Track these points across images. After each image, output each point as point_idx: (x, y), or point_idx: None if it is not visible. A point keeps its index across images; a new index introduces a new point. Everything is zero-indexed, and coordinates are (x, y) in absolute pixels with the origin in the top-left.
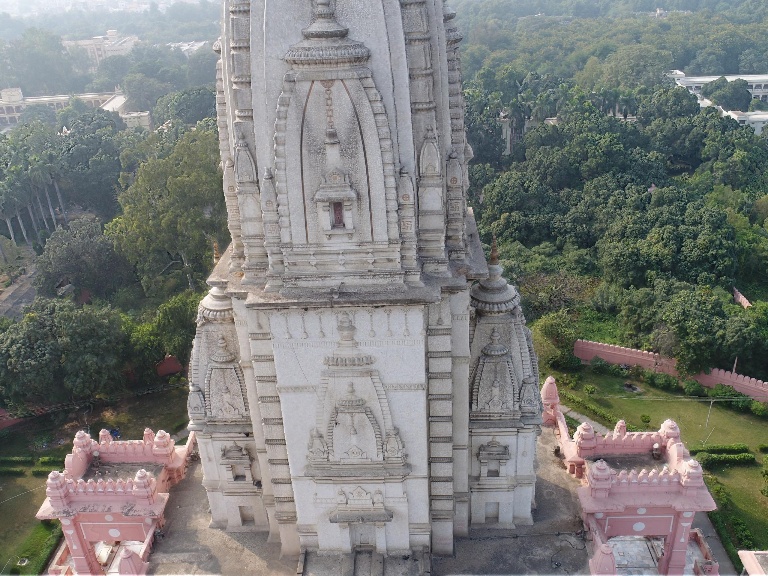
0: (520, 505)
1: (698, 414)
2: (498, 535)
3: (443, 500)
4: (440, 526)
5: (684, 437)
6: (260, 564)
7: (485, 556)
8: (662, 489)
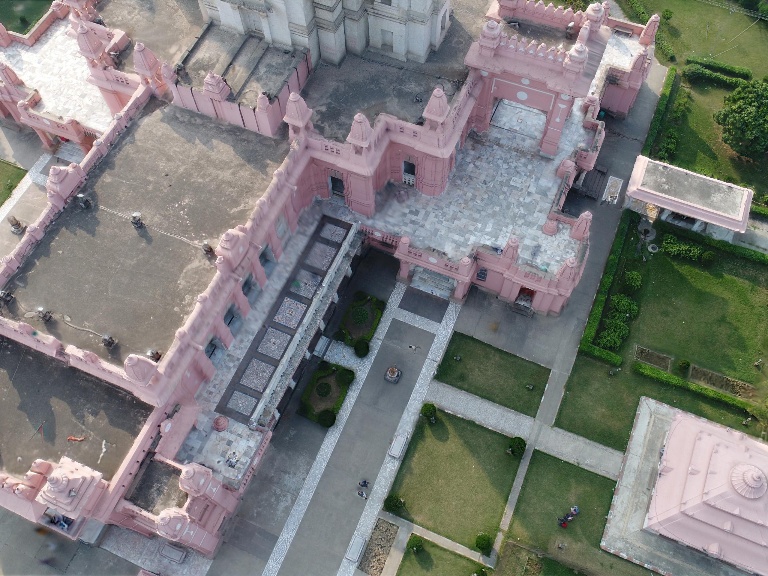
0: (414, 41)
1: (733, 27)
2: (387, 62)
3: (324, 10)
4: (325, 35)
5: (696, 45)
6: (185, 25)
7: (364, 75)
8: (547, 65)
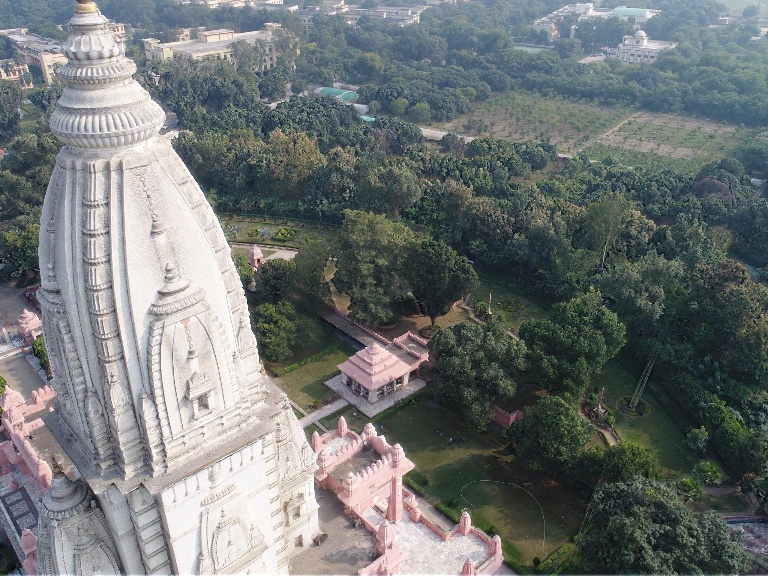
0: None
1: None
2: None
3: None
4: None
5: None
6: None
7: None
8: None
